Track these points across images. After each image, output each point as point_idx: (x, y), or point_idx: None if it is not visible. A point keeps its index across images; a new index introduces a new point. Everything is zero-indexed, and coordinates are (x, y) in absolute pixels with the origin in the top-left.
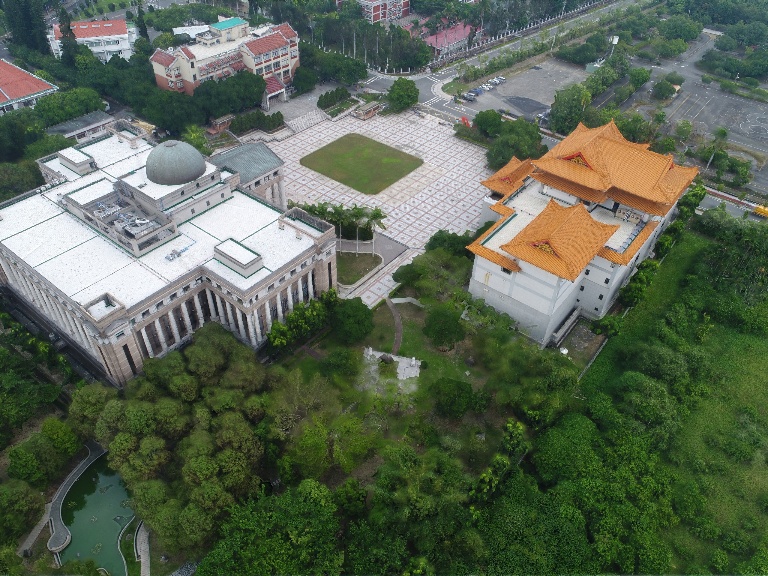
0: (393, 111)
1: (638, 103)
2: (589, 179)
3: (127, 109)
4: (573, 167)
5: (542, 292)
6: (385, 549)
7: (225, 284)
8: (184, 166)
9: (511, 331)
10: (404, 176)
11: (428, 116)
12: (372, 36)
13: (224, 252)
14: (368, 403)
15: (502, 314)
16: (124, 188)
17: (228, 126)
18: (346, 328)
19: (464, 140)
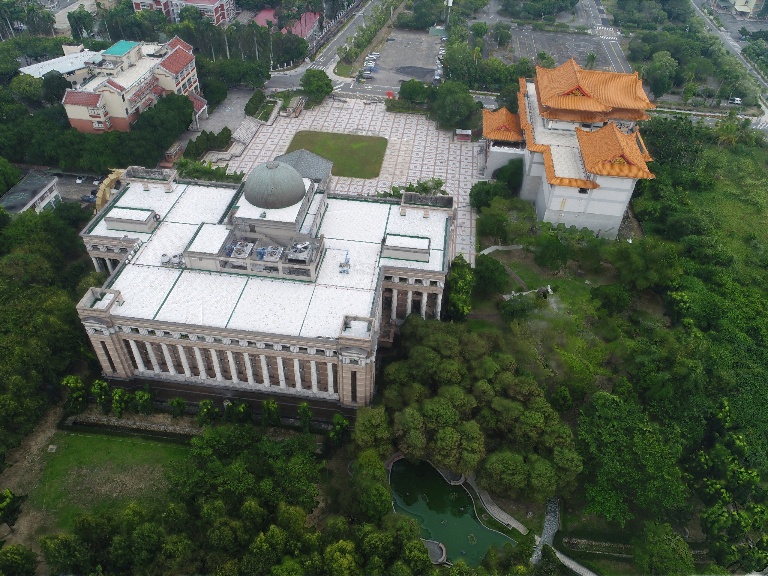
0: (315, 103)
1: (491, 52)
2: (592, 105)
3: (35, 169)
4: (574, 99)
5: (617, 198)
6: (689, 409)
7: (417, 273)
8: (297, 183)
9: (601, 238)
10: (384, 155)
11: (348, 100)
12: (249, 36)
13: (398, 246)
14: (571, 325)
15: (583, 229)
16: (239, 225)
17: (179, 155)
18: (499, 280)
19: (398, 112)
